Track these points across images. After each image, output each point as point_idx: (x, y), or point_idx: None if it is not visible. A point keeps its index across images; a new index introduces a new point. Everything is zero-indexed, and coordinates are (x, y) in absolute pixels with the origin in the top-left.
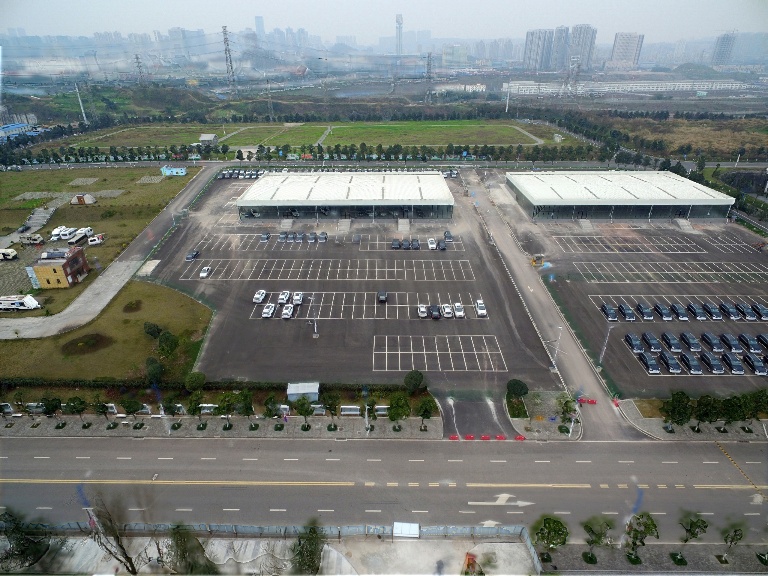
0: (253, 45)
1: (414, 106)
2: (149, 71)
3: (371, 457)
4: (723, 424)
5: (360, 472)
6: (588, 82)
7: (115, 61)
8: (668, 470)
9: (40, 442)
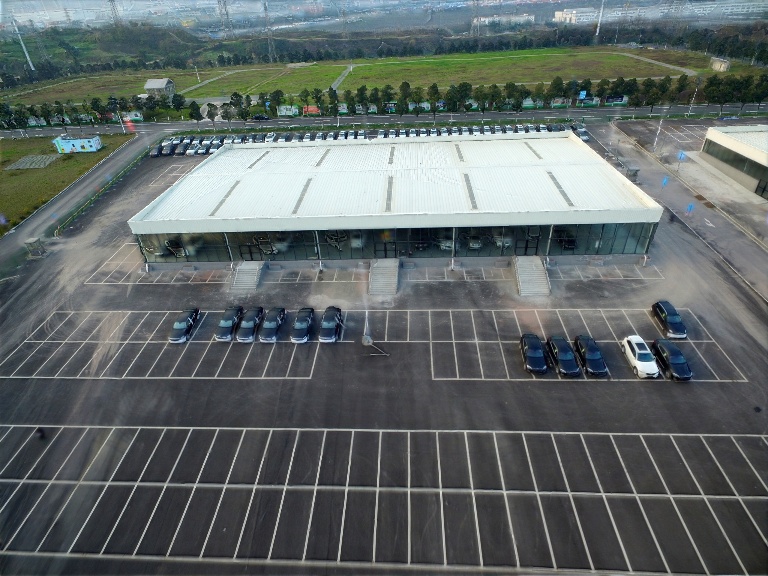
0: None
1: (458, 38)
2: (124, 7)
3: None
4: None
5: None
6: None
7: None
8: None
9: None
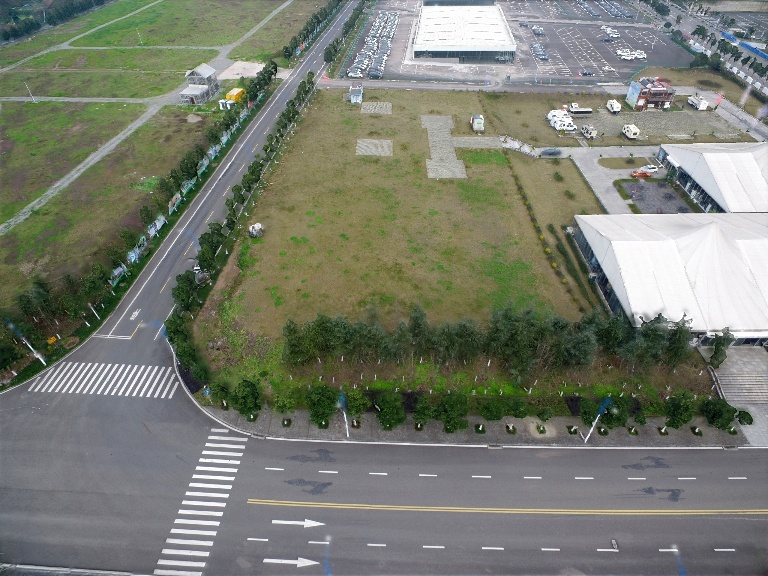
0: None
1: None
2: None
3: None
4: None
5: None
6: None
7: None
8: None
9: (767, 85)
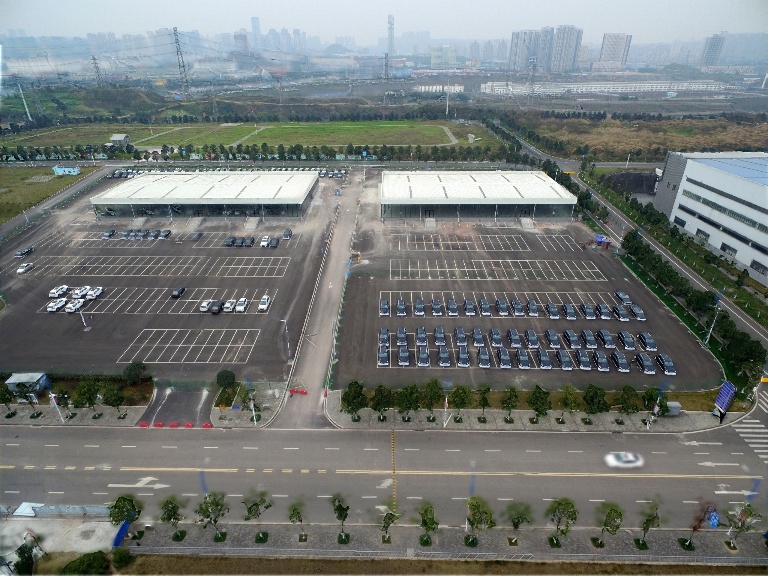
0: (205, 46)
1: (370, 107)
2: (106, 72)
3: (51, 443)
4: (413, 414)
5: (29, 456)
6: (544, 83)
7: (68, 62)
8: (324, 456)
9: None
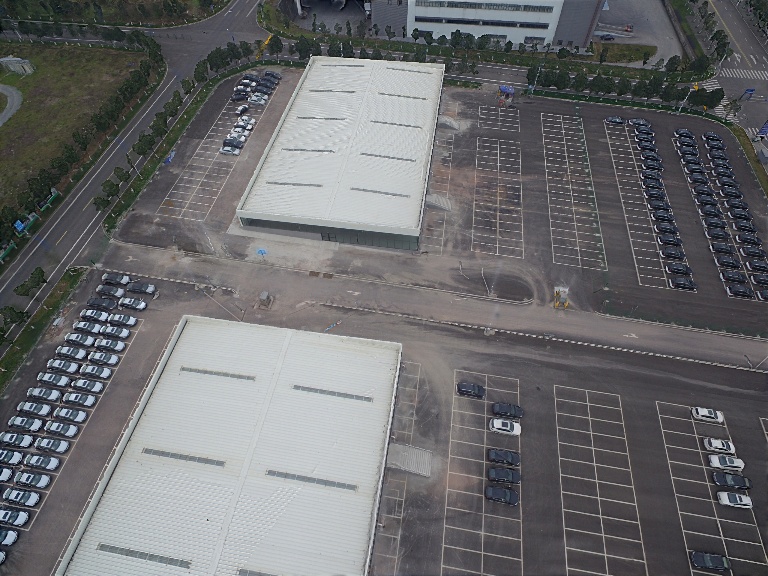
0: None
1: None
2: None
3: None
4: None
5: None
6: None
7: None
8: None
9: None
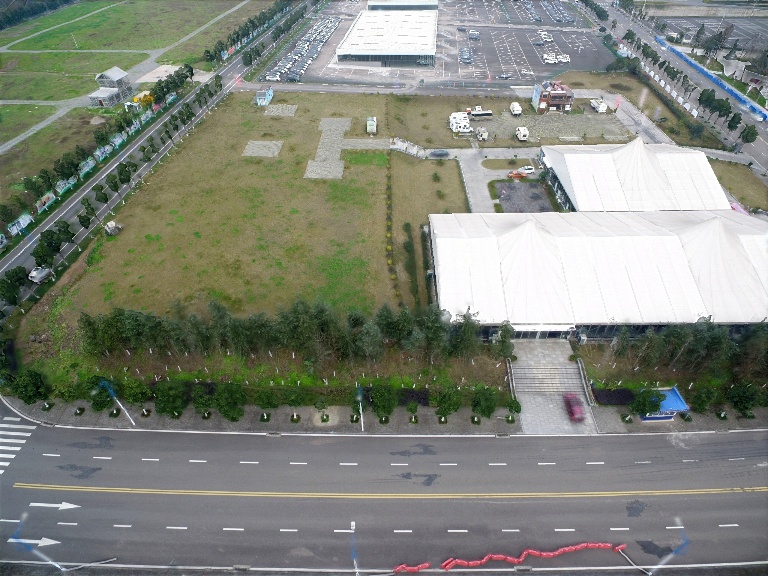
0: None
1: None
2: None
3: None
4: (594, 22)
5: None
6: None
7: None
8: None
9: None
